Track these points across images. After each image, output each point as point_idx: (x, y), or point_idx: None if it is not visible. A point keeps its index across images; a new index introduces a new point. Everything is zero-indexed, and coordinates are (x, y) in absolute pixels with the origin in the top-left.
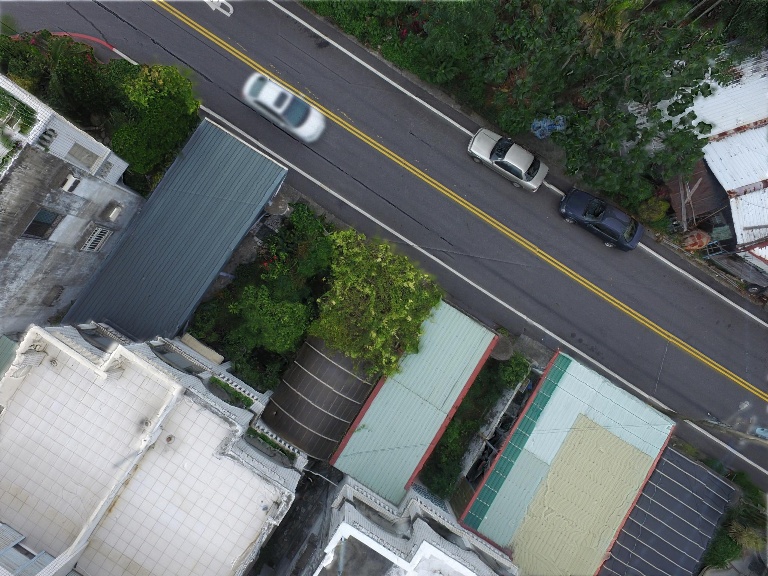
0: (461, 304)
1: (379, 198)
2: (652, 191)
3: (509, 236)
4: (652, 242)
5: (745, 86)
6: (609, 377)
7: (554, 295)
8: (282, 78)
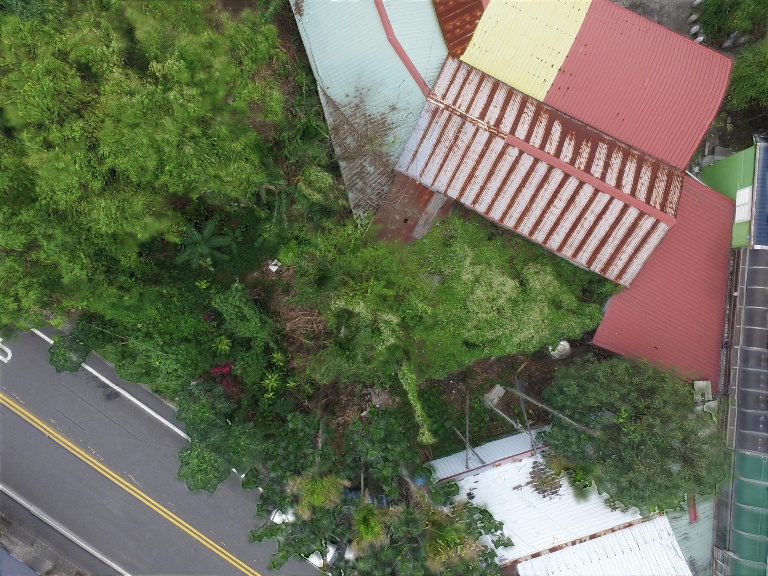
0: None
1: (167, 575)
2: None
3: None
4: None
5: (565, 497)
6: None
7: None
8: (63, 435)
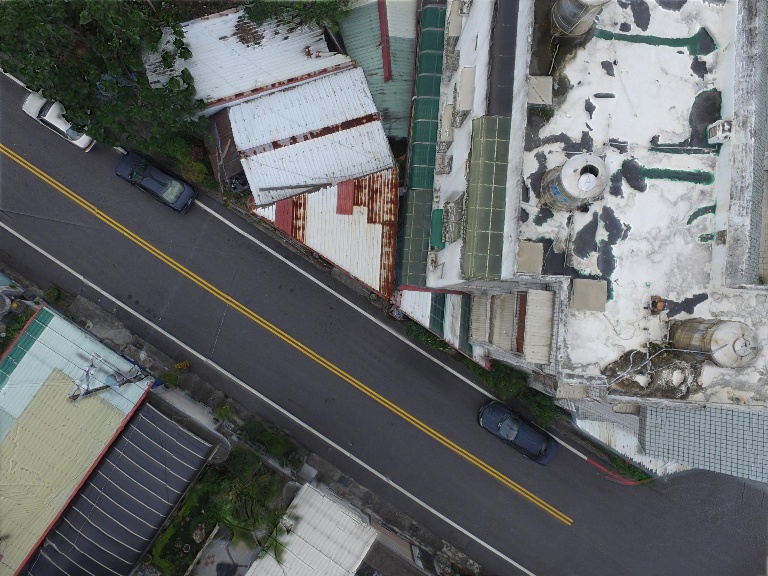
0: (18, 264)
1: None
2: (188, 152)
3: (68, 196)
4: (219, 206)
5: (267, 48)
6: (165, 339)
7: (111, 256)
8: None
